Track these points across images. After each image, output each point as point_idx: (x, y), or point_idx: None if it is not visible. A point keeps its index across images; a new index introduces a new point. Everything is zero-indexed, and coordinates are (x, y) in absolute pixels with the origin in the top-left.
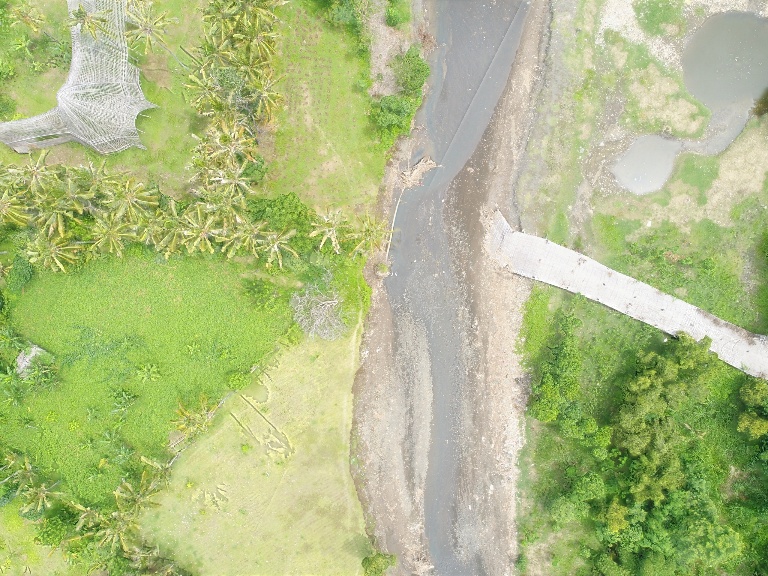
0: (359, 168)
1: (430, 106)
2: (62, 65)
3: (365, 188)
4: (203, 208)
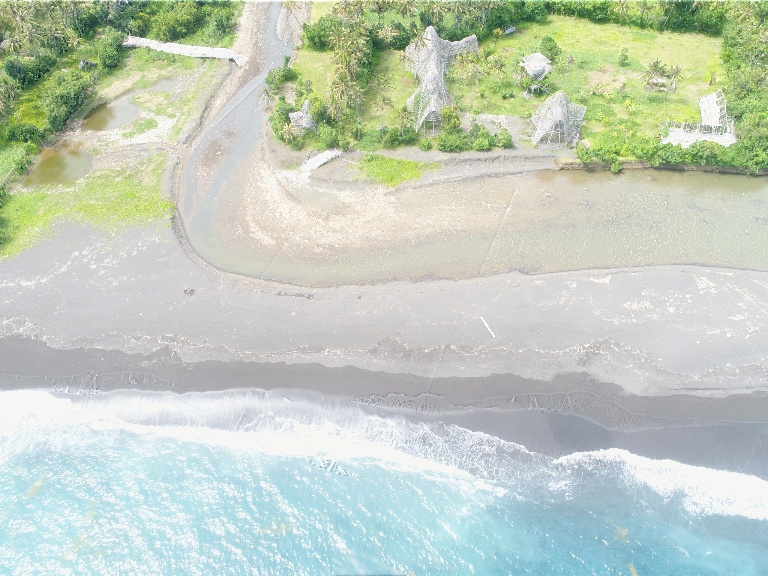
0: None
1: None
2: None
3: None
4: None
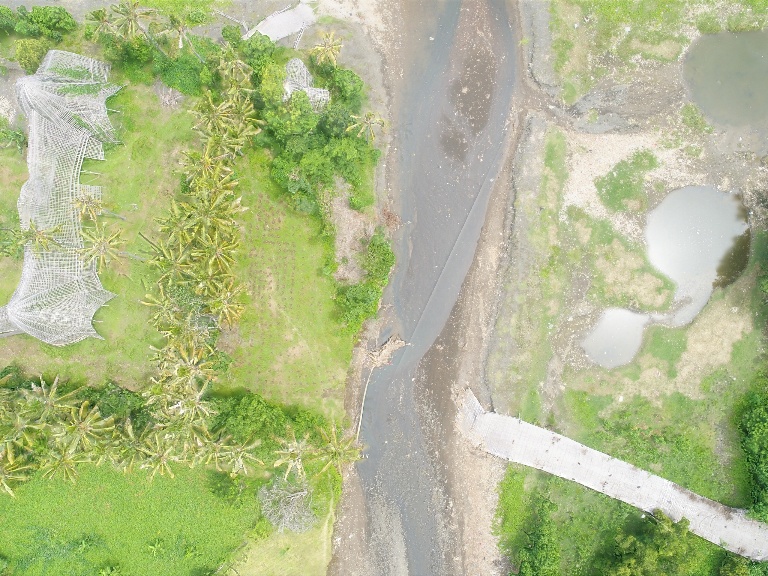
0: (326, 353)
1: (397, 284)
2: (15, 254)
3: (333, 373)
4: (162, 435)
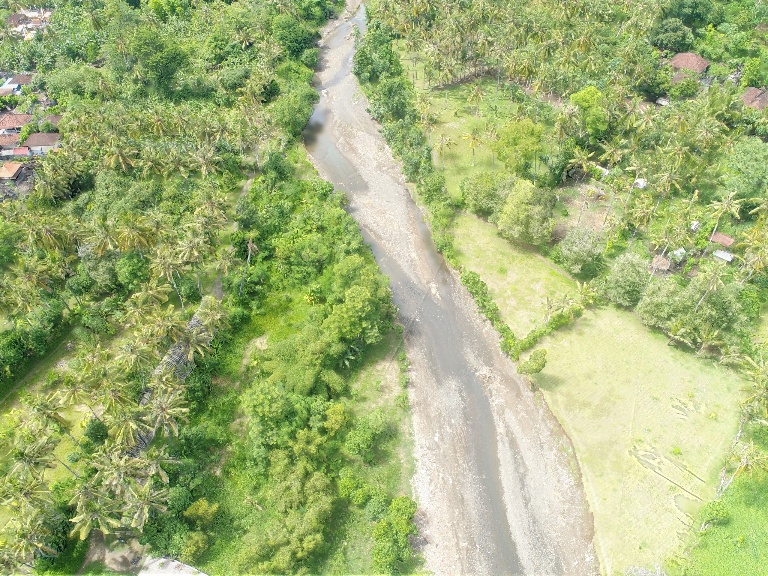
0: None
1: None
2: None
3: None
4: None
